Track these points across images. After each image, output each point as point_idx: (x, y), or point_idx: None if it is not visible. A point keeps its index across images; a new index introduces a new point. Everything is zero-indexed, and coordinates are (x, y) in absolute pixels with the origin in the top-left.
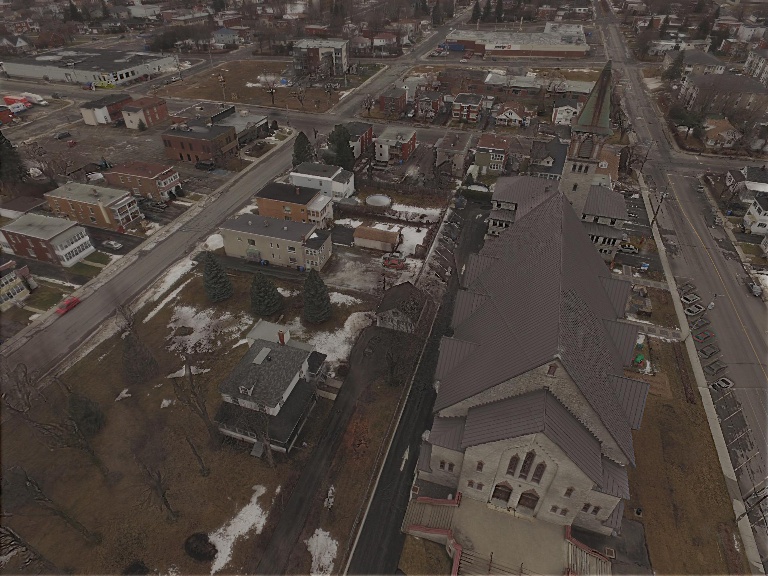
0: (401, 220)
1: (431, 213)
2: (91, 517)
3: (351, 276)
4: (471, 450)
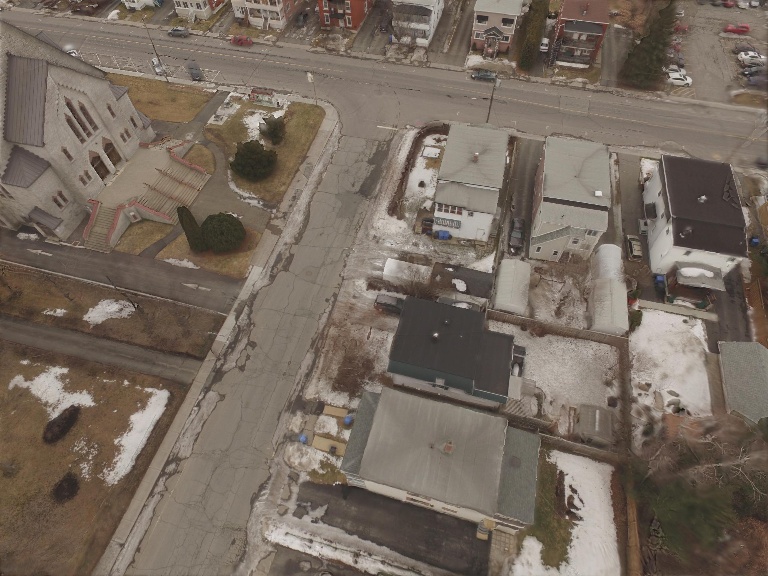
0: None
1: None
2: None
3: None
4: (48, 144)
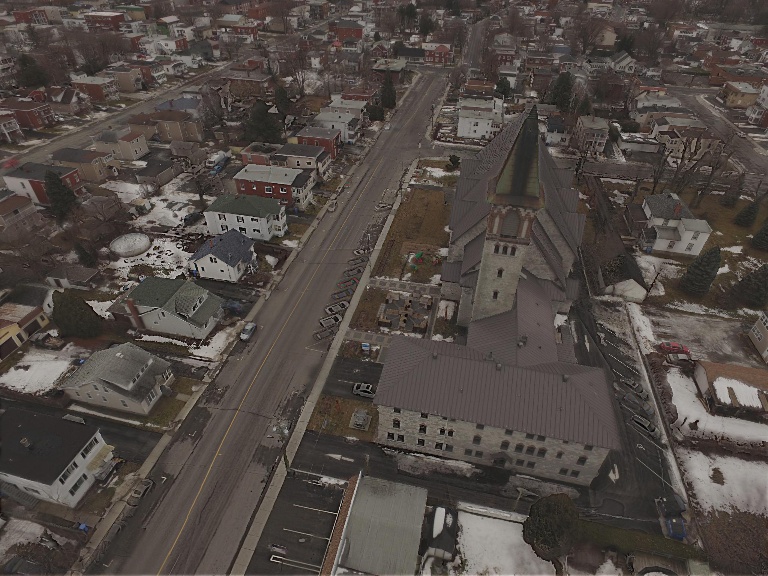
0: (746, 457)
1: (711, 490)
2: (685, 199)
3: (707, 332)
4: None
